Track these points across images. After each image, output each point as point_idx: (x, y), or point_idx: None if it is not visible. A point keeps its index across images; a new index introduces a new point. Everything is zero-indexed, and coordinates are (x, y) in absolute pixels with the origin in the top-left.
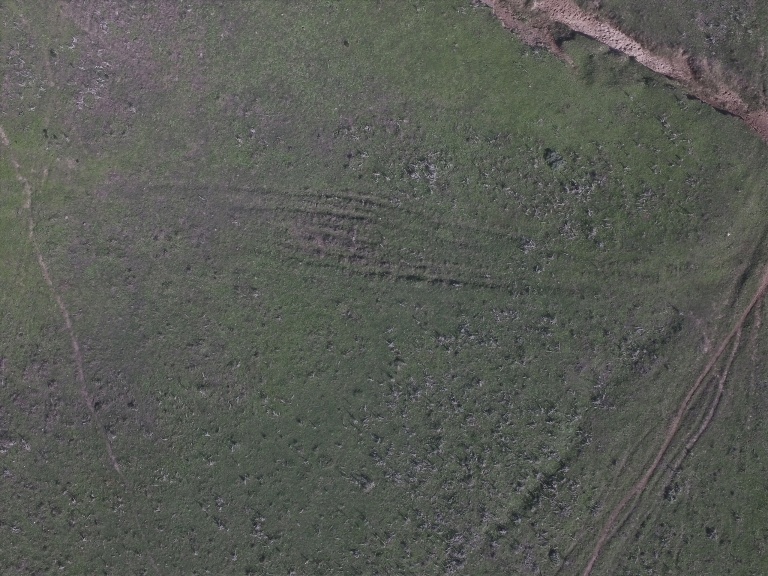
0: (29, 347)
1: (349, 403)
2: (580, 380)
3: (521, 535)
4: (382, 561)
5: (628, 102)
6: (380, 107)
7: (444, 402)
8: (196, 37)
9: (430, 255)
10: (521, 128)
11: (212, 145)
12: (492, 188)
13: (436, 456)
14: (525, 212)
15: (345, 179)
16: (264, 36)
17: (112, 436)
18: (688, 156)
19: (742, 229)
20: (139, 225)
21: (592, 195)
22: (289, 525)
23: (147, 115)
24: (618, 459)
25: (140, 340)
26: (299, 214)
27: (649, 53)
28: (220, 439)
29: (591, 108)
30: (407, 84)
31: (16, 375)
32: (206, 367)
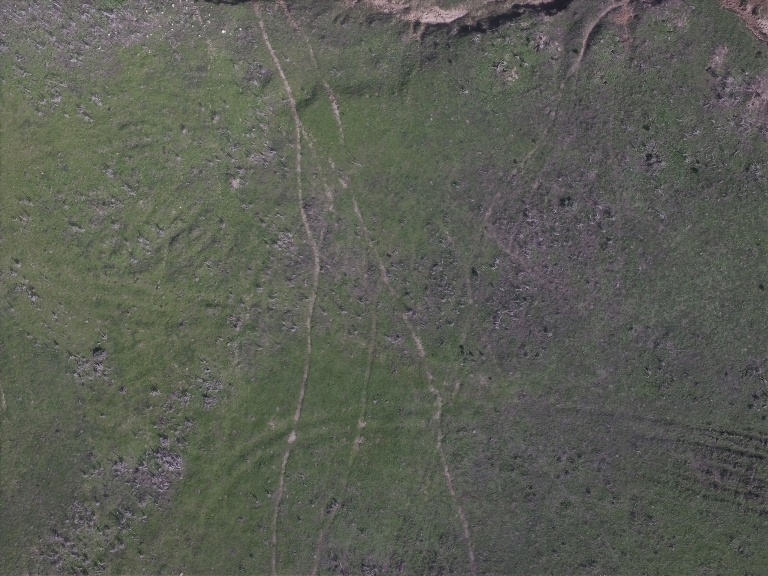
0: (428, 553)
1: None
2: None
3: None
4: None
5: None
6: None
7: None
8: (614, 268)
9: None
10: None
11: (621, 374)
12: None
13: None
14: None
15: (748, 418)
16: (681, 272)
17: None
18: None
19: None
20: (543, 445)
21: None
22: None
23: (561, 339)
24: None
25: (535, 556)
26: (700, 448)
27: None
28: None
29: None
30: None
31: None
32: None
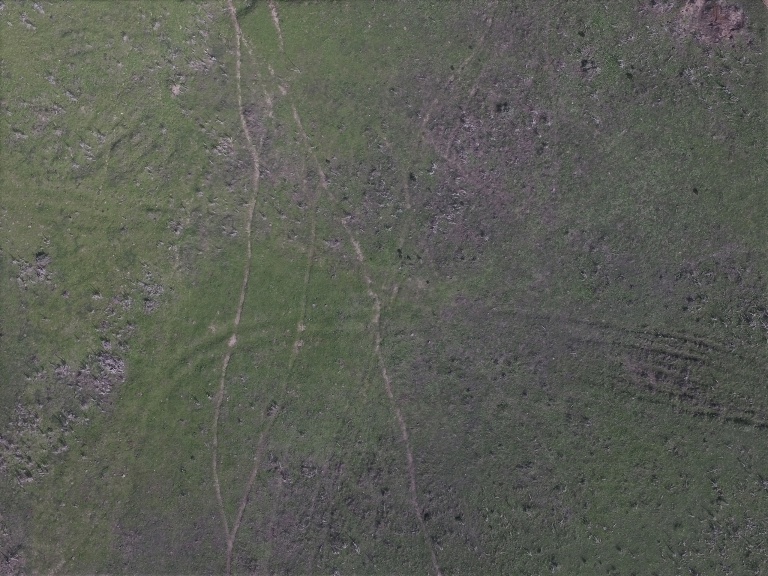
0: (366, 455)
1: (669, 537)
2: None
3: None
4: None
5: None
6: (723, 255)
7: (762, 545)
8: (550, 172)
9: (759, 401)
10: None
11: (557, 277)
12: None
13: None
14: None
15: (683, 321)
16: (616, 177)
17: (439, 547)
18: None
19: None
20: (480, 348)
21: None
22: None
23: (497, 243)
24: None
25: (472, 458)
26: (635, 350)
27: None
28: (541, 559)
29: None
30: (752, 235)
31: (352, 481)
32: (533, 489)
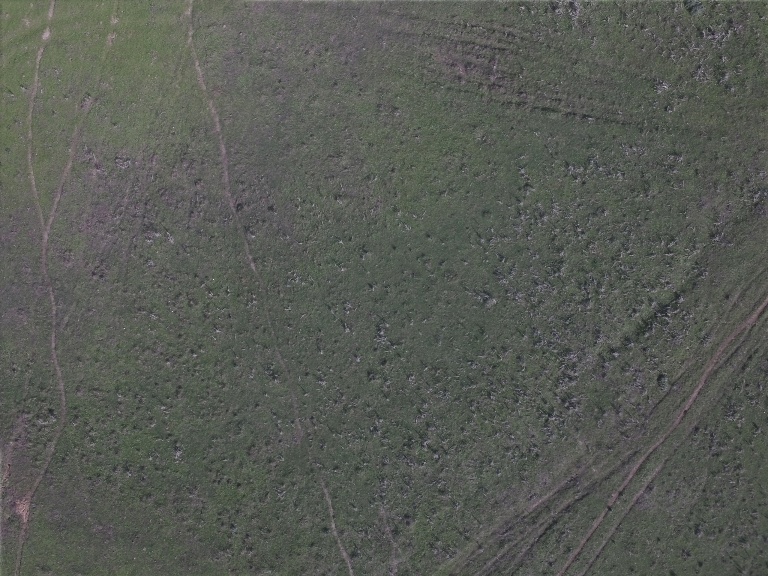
0: (180, 146)
1: (477, 223)
2: (701, 217)
3: (632, 359)
4: (498, 373)
5: None
6: None
7: (568, 229)
8: None
9: (566, 89)
10: None
11: None
12: (631, 29)
13: (557, 279)
14: (661, 53)
15: (491, 10)
16: None
17: (251, 236)
18: None
19: None
20: (292, 39)
21: (727, 42)
22: (411, 333)
23: None
24: (731, 294)
25: (284, 148)
26: (444, 40)
27: None
28: (352, 248)
29: None
30: None
31: (165, 171)
32: (344, 179)
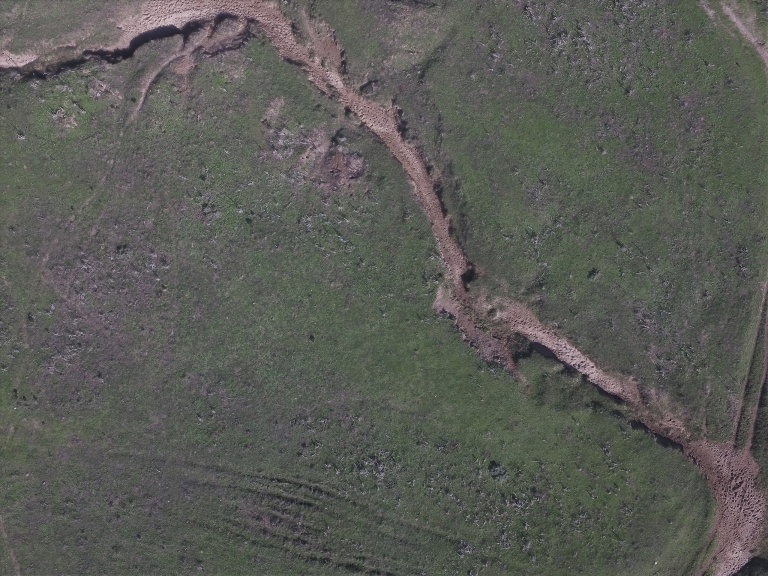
0: None
1: None
2: None
3: None
4: None
5: (574, 426)
6: (338, 402)
7: None
8: (169, 315)
9: (370, 548)
10: (470, 438)
11: (174, 420)
12: (436, 491)
13: None
14: (465, 518)
15: (297, 466)
16: (234, 322)
17: None
18: (625, 485)
19: (670, 558)
20: (96, 489)
21: (530, 510)
22: None
23: (114, 385)
24: None
25: None
26: (250, 495)
27: (602, 372)
28: None
29: (538, 428)
30: (366, 383)
31: None
32: None
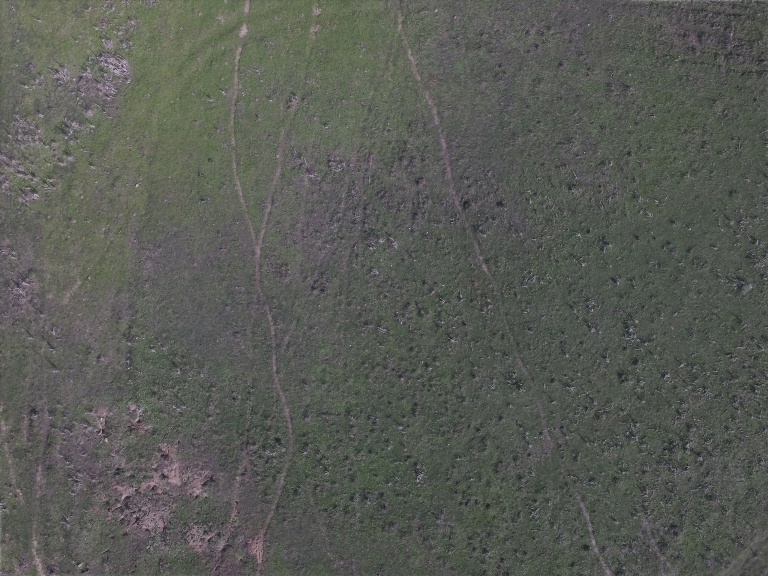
0: (397, 143)
1: (725, 204)
2: None
3: None
4: (760, 364)
5: None
6: None
7: None
8: None
9: None
10: None
11: None
12: None
13: None
14: None
15: None
16: None
17: (481, 235)
18: None
19: None
20: (510, 19)
21: None
22: (662, 328)
23: None
24: None
25: (510, 138)
26: (674, 10)
27: None
28: (591, 240)
29: None
30: None
31: (383, 172)
32: (577, 166)
